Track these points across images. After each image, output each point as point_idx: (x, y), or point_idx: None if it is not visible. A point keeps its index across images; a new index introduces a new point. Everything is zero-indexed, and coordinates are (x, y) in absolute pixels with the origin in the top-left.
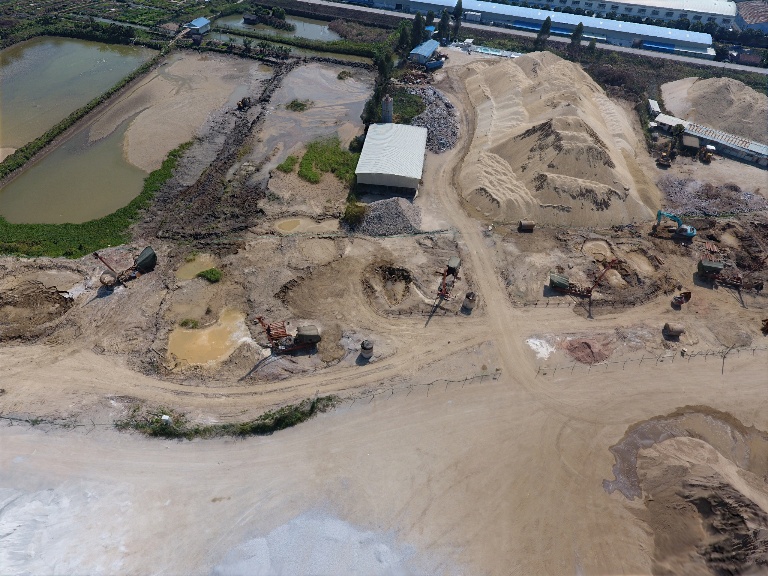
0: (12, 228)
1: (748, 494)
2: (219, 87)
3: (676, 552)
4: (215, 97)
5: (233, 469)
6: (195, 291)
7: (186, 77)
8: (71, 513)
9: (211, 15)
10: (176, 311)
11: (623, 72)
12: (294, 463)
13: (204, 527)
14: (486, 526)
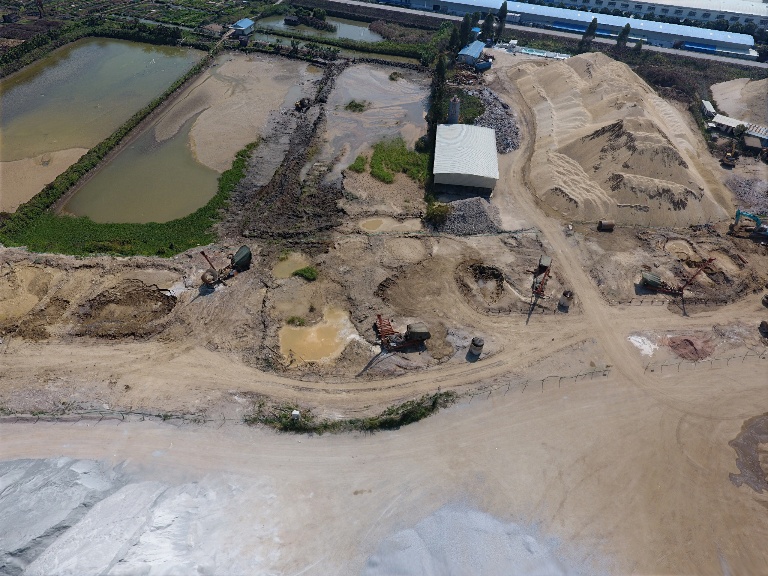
0: (99, 227)
1: None
2: (273, 88)
3: None
4: (271, 98)
5: (368, 463)
6: (295, 289)
7: (238, 78)
8: (220, 505)
9: (252, 16)
10: (280, 309)
11: (673, 73)
12: (426, 457)
13: (351, 519)
14: (625, 518)
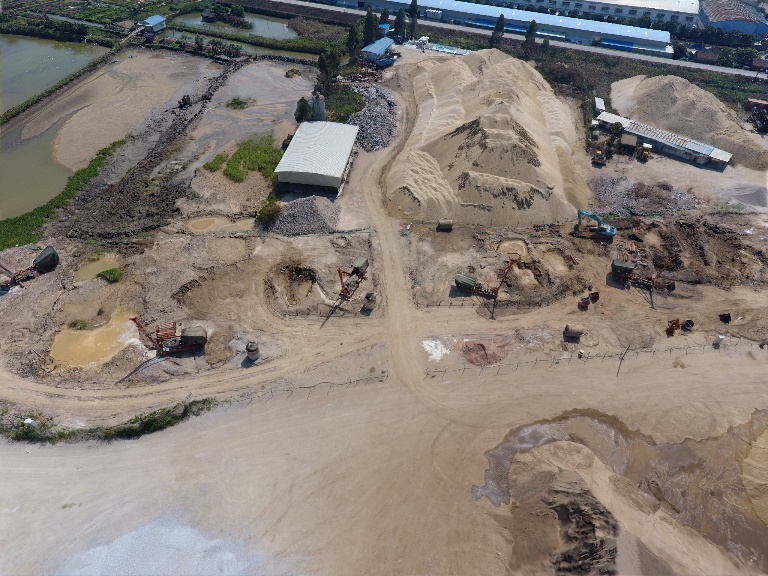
0: None
1: (608, 501)
2: (164, 85)
3: (531, 561)
4: (158, 95)
5: (91, 474)
6: (91, 291)
7: (133, 75)
8: None
9: (170, 13)
10: (68, 312)
11: (573, 70)
12: (155, 468)
13: (48, 535)
14: (341, 534)
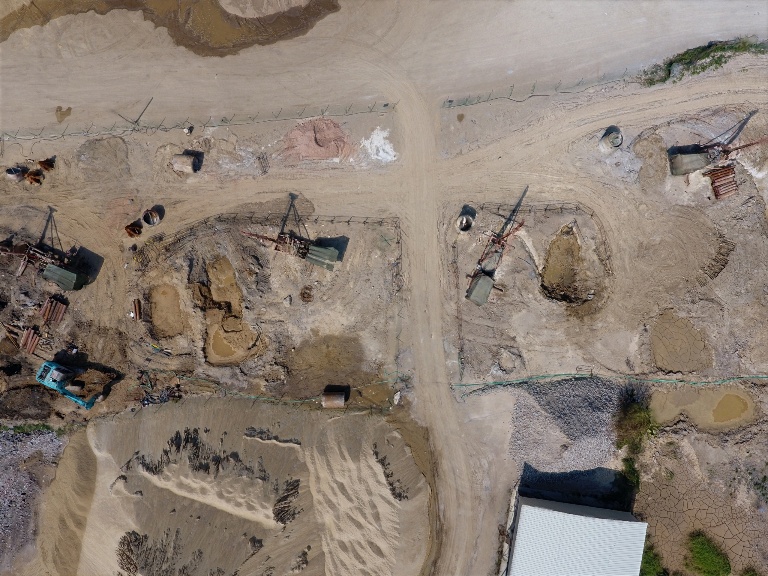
0: None
1: None
2: None
3: None
4: None
5: (743, 7)
6: None
7: None
8: None
9: None
10: None
11: None
12: (683, 8)
13: None
14: None
